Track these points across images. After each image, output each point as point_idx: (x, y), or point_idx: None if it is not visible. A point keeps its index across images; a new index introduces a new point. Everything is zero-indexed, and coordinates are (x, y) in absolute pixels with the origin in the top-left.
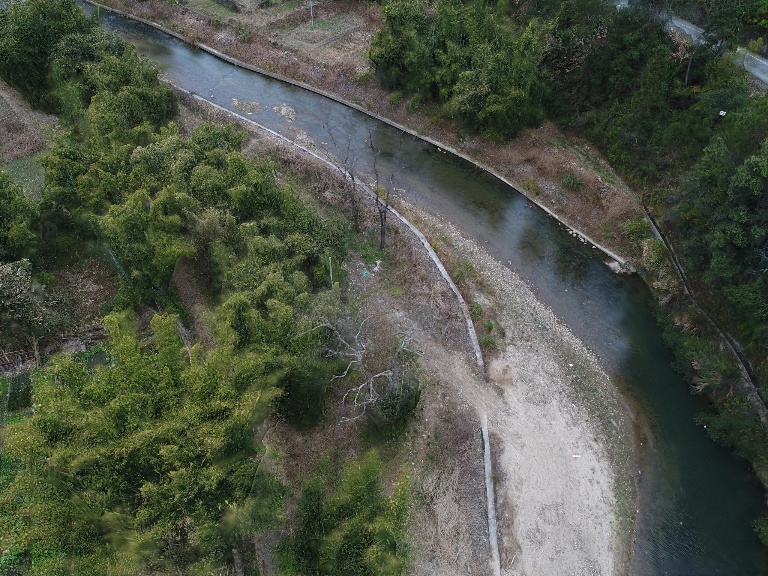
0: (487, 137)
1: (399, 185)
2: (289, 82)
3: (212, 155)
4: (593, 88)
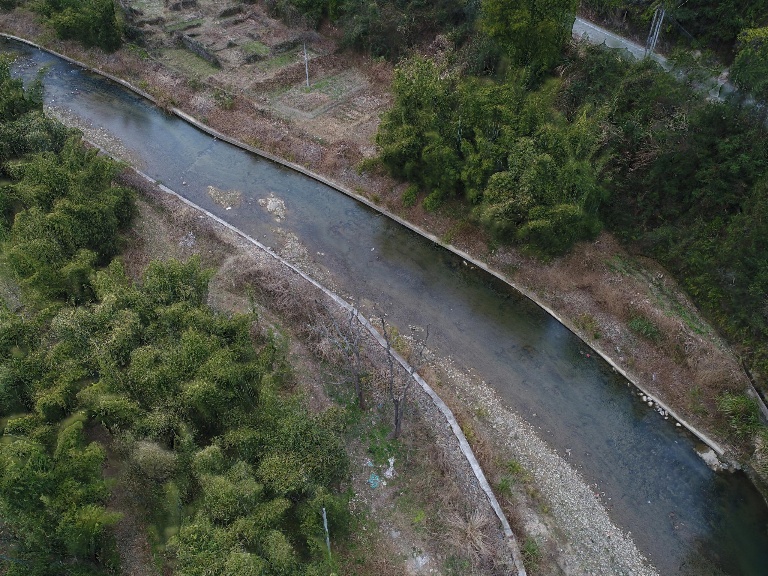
0: (526, 249)
1: (416, 320)
2: (279, 162)
3: (164, 317)
4: (666, 196)
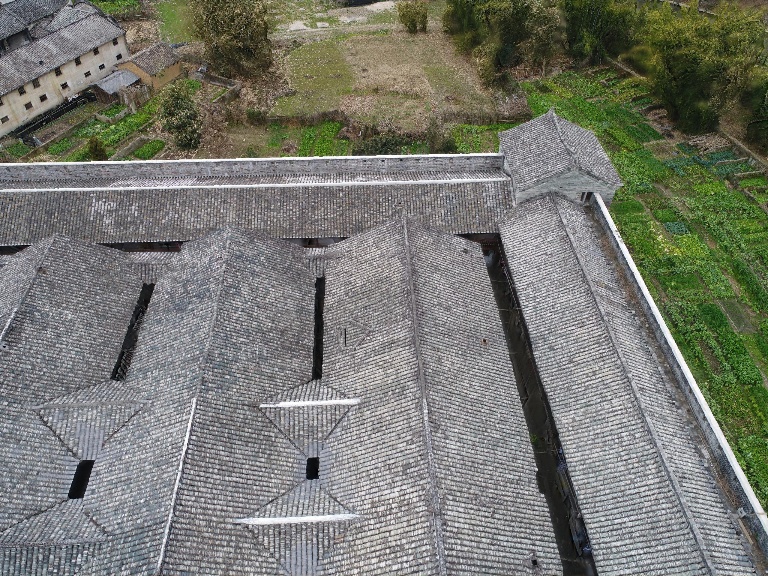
0: None
1: None
2: None
3: None
4: None
